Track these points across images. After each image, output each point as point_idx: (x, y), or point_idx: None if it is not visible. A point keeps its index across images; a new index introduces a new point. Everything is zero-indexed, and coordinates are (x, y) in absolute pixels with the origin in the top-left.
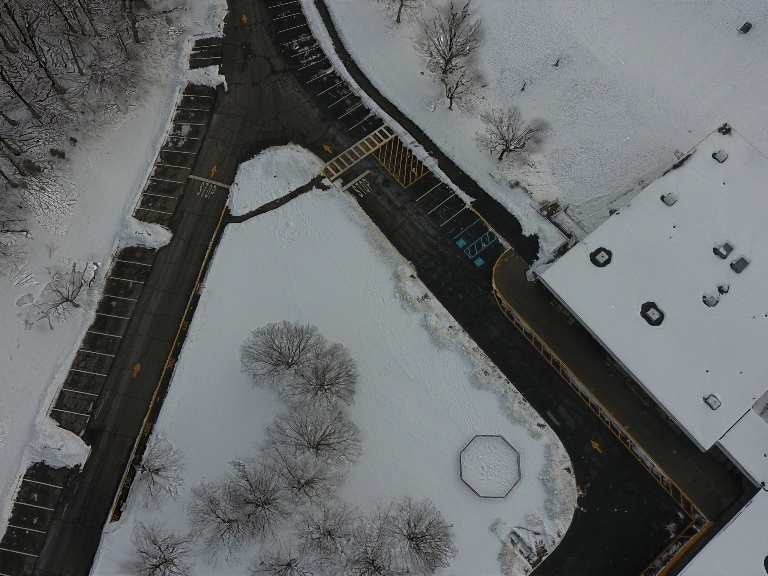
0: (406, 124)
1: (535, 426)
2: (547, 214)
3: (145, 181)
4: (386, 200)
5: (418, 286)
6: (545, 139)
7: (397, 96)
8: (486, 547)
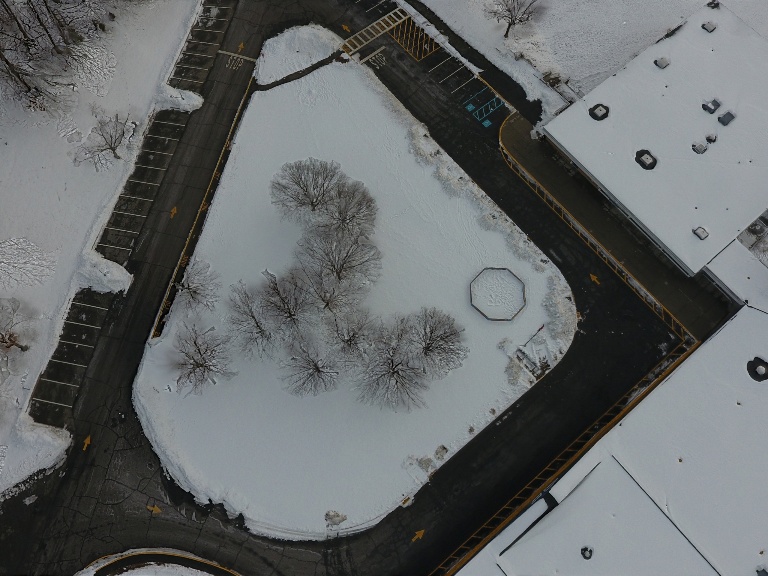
0: (419, 7)
1: (539, 261)
2: None
3: (178, 54)
4: (401, 71)
5: (431, 143)
6: (547, 24)
7: None
8: (494, 362)
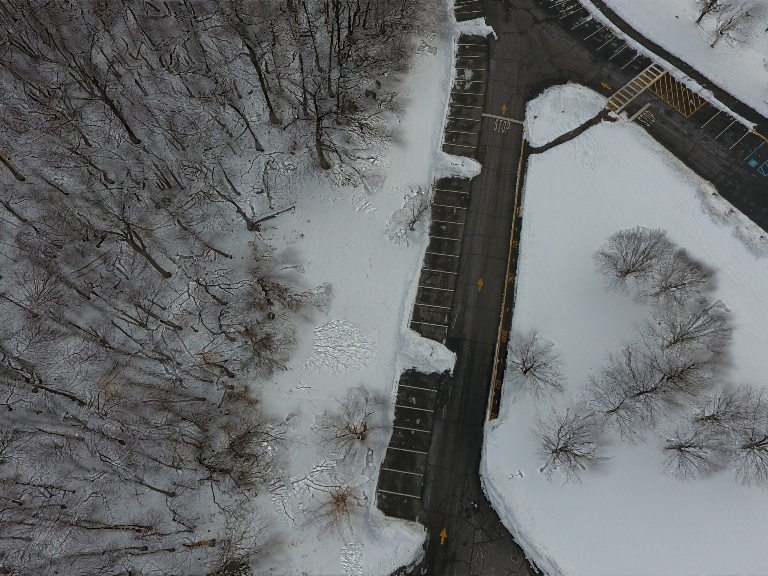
0: (674, 61)
1: None
2: None
3: (445, 119)
4: (672, 128)
5: (723, 202)
6: None
7: (660, 37)
8: None
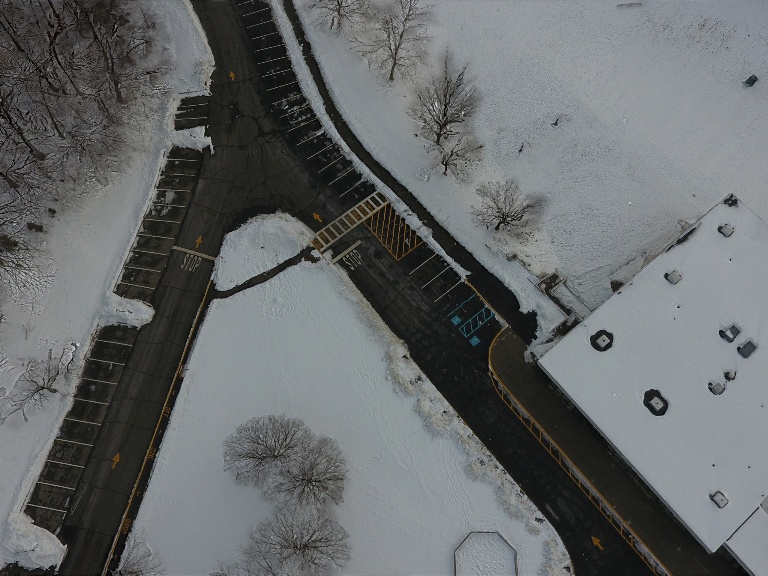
0: (399, 191)
1: (533, 521)
2: (546, 287)
3: (127, 253)
4: (378, 273)
5: (411, 368)
6: (544, 204)
7: (390, 160)
8: None
